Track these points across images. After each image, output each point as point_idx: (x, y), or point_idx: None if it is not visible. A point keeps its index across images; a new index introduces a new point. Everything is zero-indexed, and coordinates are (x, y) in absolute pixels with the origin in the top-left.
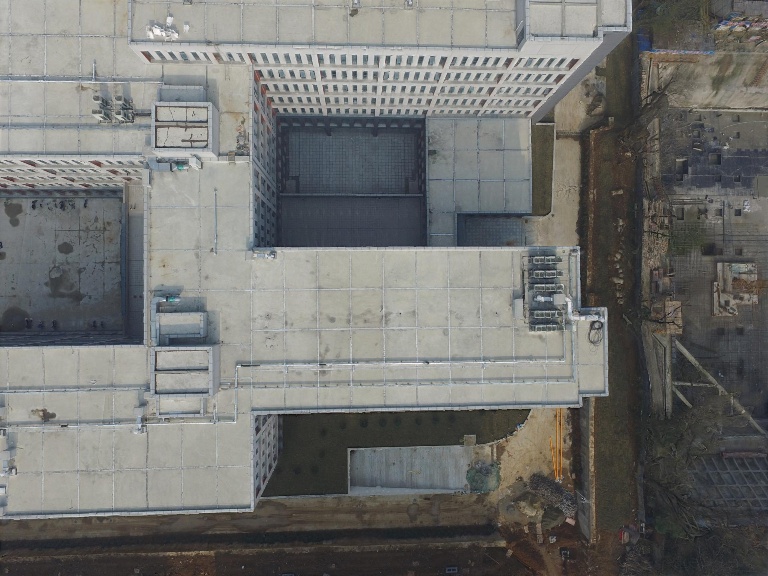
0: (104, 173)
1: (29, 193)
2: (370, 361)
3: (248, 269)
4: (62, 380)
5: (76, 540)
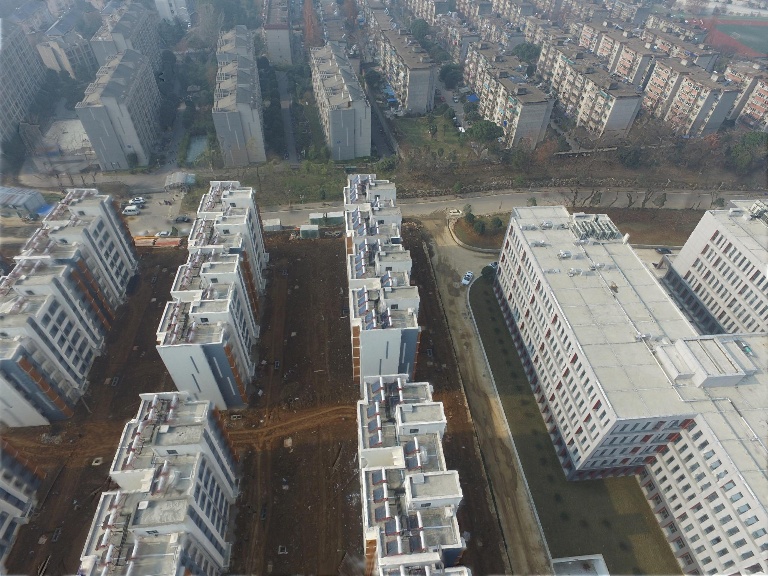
0: (761, 318)
1: (676, 292)
2: None
3: None
4: (643, 294)
5: (449, 330)
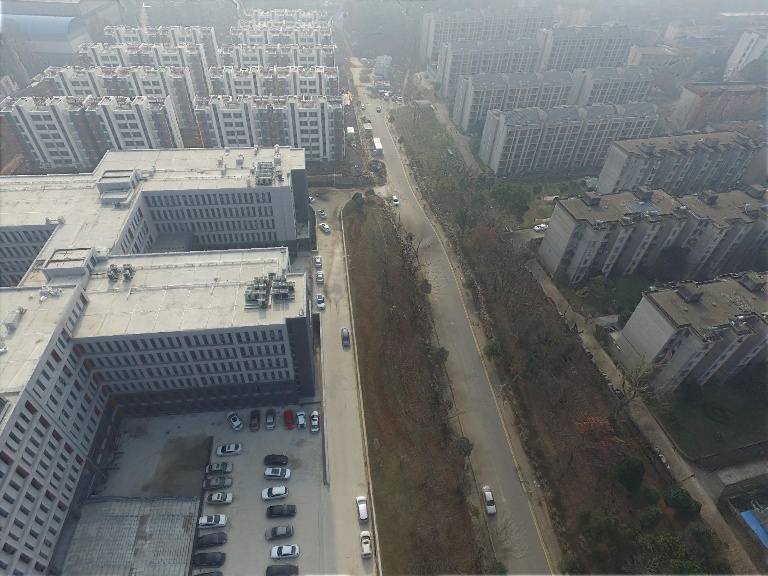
0: None
1: None
2: (15, 191)
3: (68, 218)
4: None
5: None
